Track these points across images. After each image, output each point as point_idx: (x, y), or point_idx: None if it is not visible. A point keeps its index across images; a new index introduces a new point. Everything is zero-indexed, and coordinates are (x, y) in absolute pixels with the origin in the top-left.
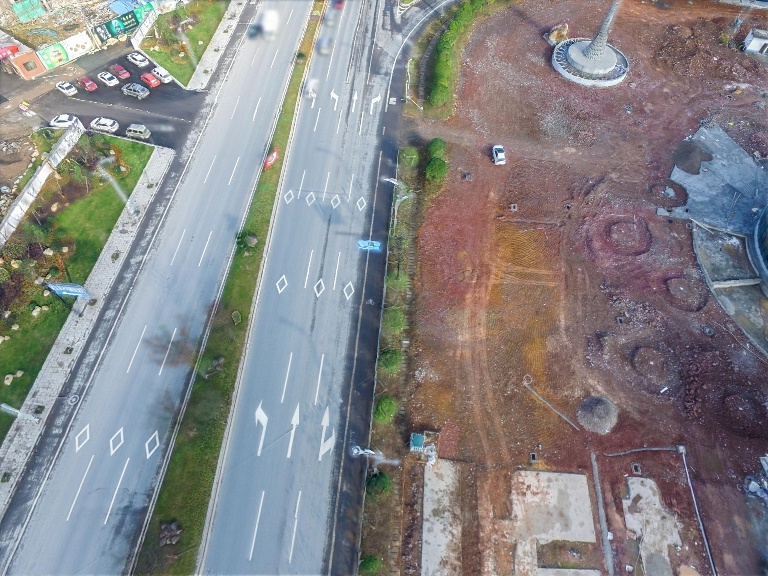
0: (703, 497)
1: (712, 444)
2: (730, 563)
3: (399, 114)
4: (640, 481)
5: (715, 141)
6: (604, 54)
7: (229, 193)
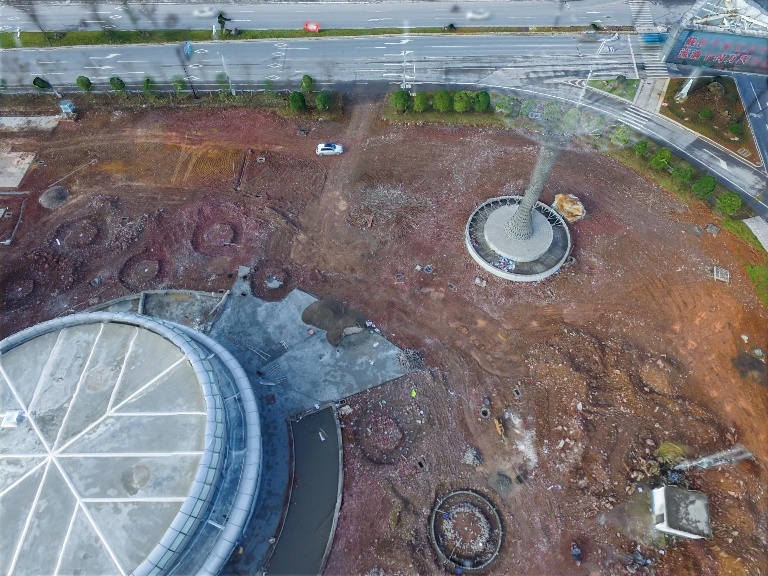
0: None
1: (3, 262)
2: None
3: (388, 91)
4: None
5: (369, 358)
6: (524, 241)
7: (285, 21)
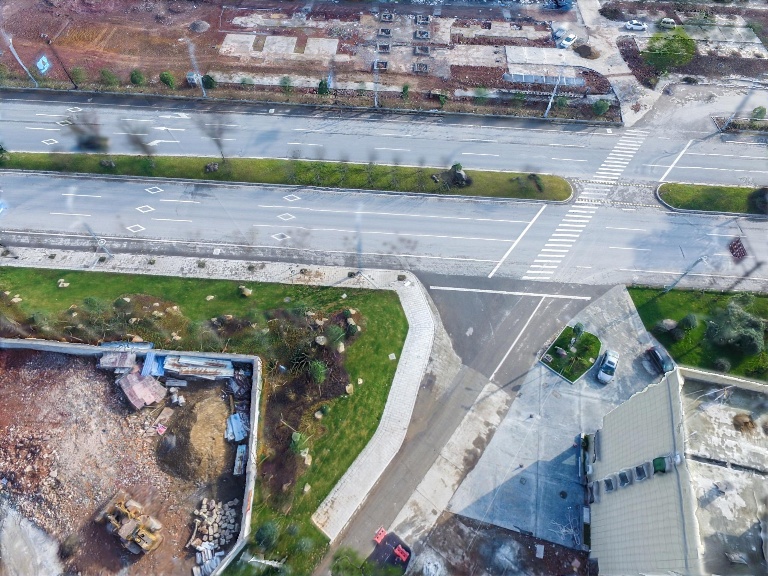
0: (246, 6)
1: None
2: (272, 5)
3: None
4: (234, 20)
5: None
6: None
7: None
